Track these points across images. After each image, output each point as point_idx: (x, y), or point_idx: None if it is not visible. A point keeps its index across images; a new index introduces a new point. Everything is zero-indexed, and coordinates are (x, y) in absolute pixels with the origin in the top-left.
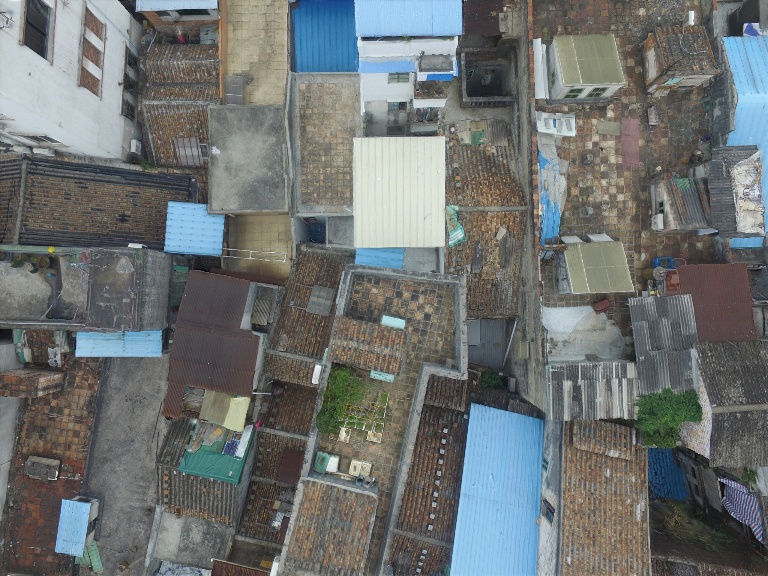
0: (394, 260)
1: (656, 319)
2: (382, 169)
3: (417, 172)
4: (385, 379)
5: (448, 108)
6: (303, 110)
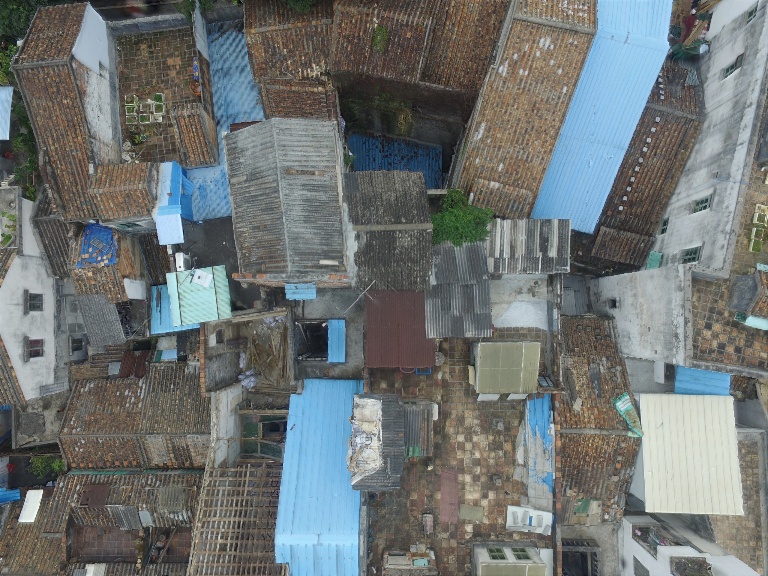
0: (686, 381)
1: (465, 315)
2: (710, 479)
3: (673, 474)
4: (765, 267)
5: (608, 540)
6: (759, 545)
